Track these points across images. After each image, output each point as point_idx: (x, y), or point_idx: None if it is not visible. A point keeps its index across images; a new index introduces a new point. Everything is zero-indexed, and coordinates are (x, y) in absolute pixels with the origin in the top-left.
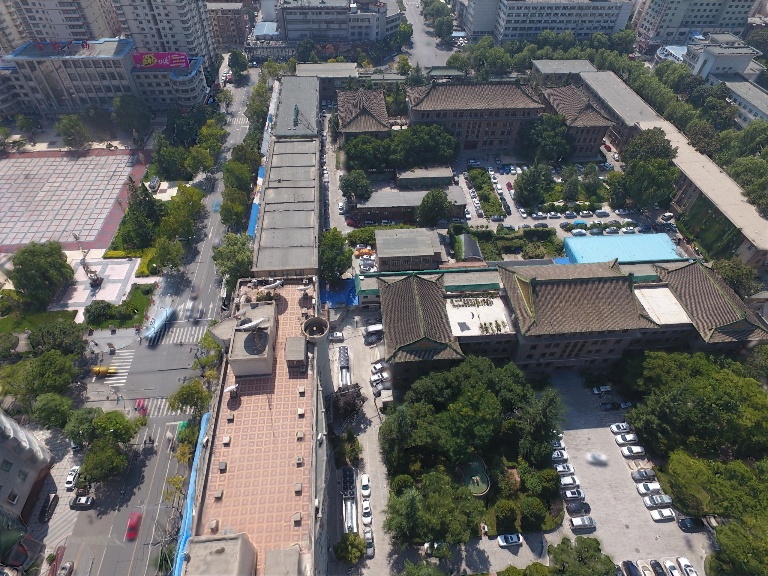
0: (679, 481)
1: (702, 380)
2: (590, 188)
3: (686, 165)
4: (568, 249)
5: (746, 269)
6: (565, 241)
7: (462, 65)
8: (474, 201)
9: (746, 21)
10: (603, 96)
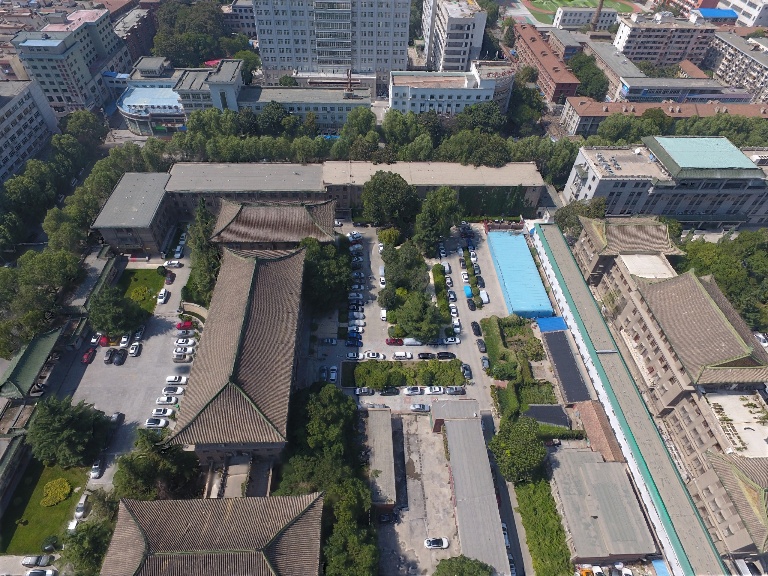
0: (760, 321)
1: (711, 272)
2: (412, 263)
3: (417, 179)
4: (528, 313)
5: (602, 201)
6: (519, 312)
7: (37, 325)
8: (434, 392)
9: (119, 38)
10: (243, 190)
